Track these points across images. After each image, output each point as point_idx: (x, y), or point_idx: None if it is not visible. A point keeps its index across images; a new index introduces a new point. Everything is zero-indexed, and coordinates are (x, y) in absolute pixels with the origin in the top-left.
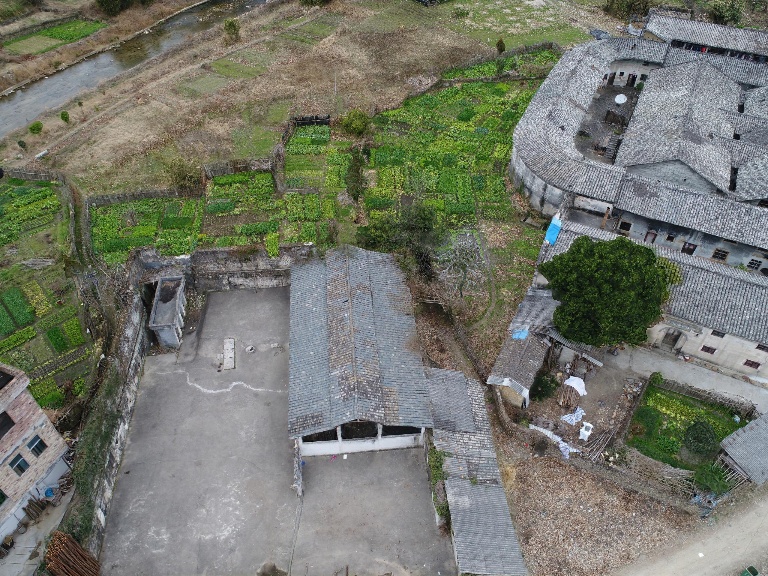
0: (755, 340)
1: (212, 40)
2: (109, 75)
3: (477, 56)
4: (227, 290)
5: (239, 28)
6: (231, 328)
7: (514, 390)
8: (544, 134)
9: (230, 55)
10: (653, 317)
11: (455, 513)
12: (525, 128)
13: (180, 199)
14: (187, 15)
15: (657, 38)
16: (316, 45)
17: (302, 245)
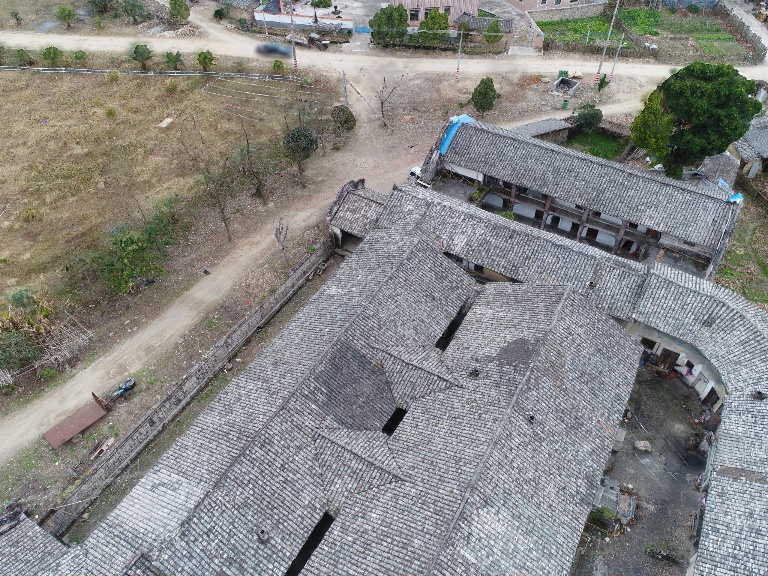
0: None
1: None
2: None
3: None
4: None
5: None
6: None
7: None
8: None
9: None
10: None
11: None
12: None
13: None
14: None
15: None
16: None
17: None
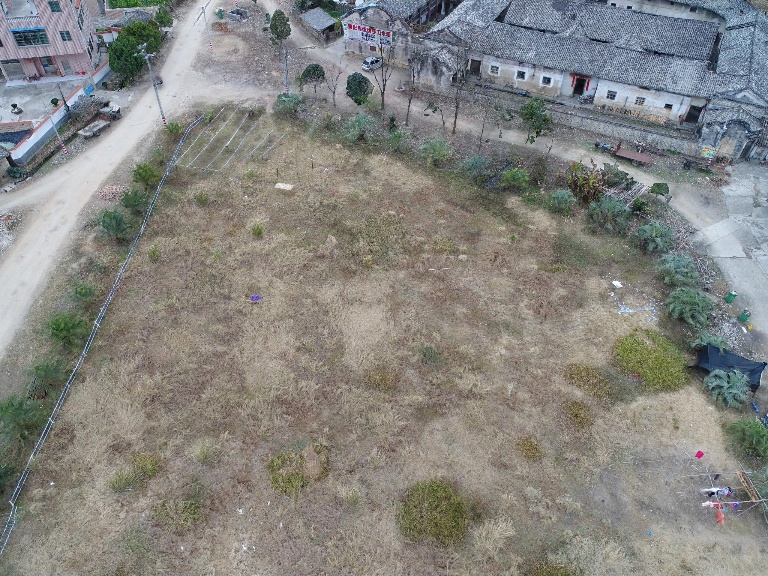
0: None
1: None
2: None
3: None
4: None
5: None
6: None
7: None
8: None
9: None
10: None
11: None
12: None
13: None
14: None
15: None
16: None
17: None
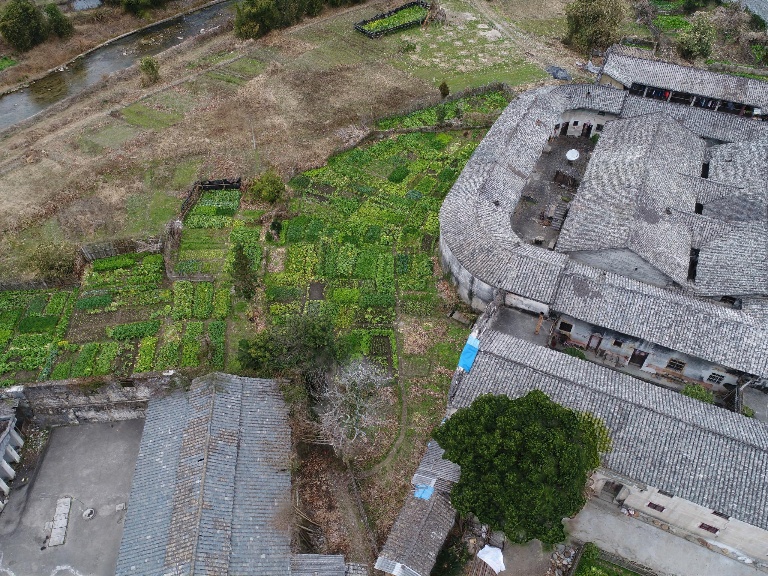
0: (710, 508)
1: (130, 80)
2: (9, 122)
3: (417, 101)
4: (76, 424)
5: (158, 67)
6: (71, 481)
7: None
8: (473, 213)
9: (145, 99)
10: (573, 509)
11: None
12: (454, 203)
13: (49, 290)
14: (111, 48)
15: (615, 81)
16: (244, 86)
17: (160, 375)
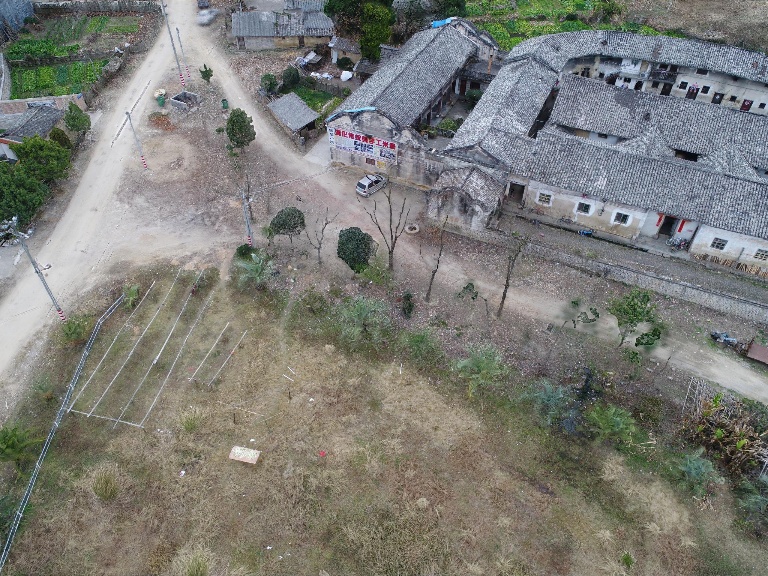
0: None
1: None
2: None
3: None
4: None
5: None
6: None
7: (331, 40)
8: None
9: None
10: None
11: (258, 13)
12: None
13: None
14: None
15: None
16: None
17: None
